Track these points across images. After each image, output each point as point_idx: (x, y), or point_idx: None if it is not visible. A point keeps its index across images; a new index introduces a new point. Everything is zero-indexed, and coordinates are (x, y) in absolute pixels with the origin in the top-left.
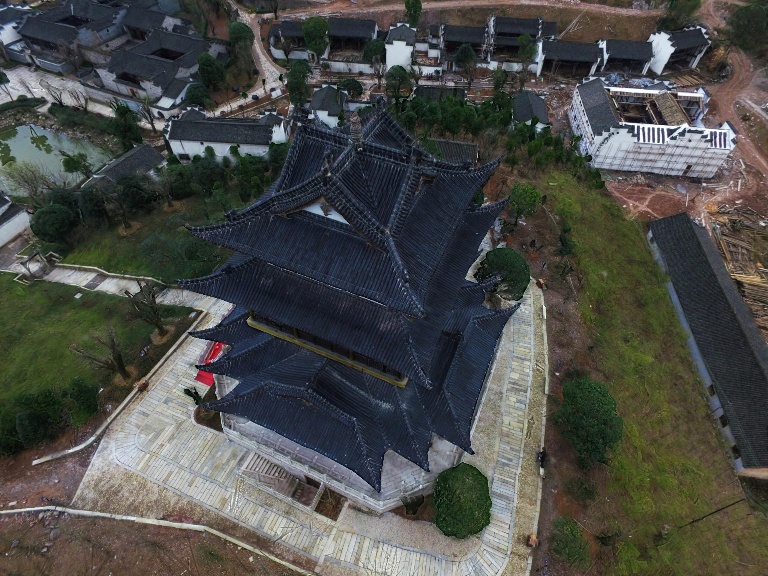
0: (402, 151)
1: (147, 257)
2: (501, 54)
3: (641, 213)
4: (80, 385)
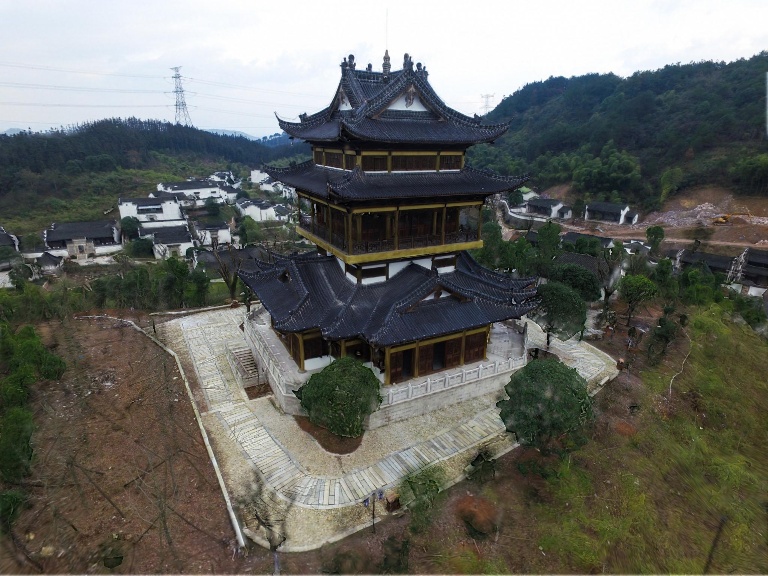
0: None
1: None
2: None
3: None
4: (201, 264)
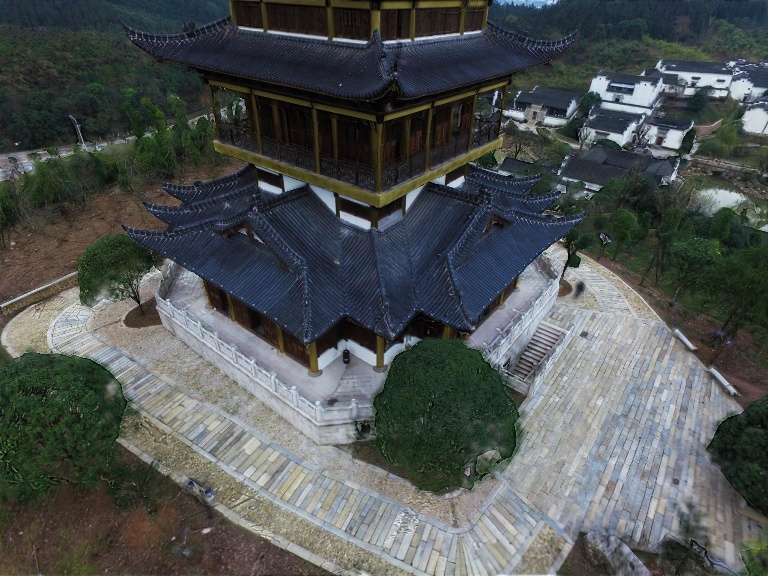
0: None
1: None
2: None
3: None
4: None
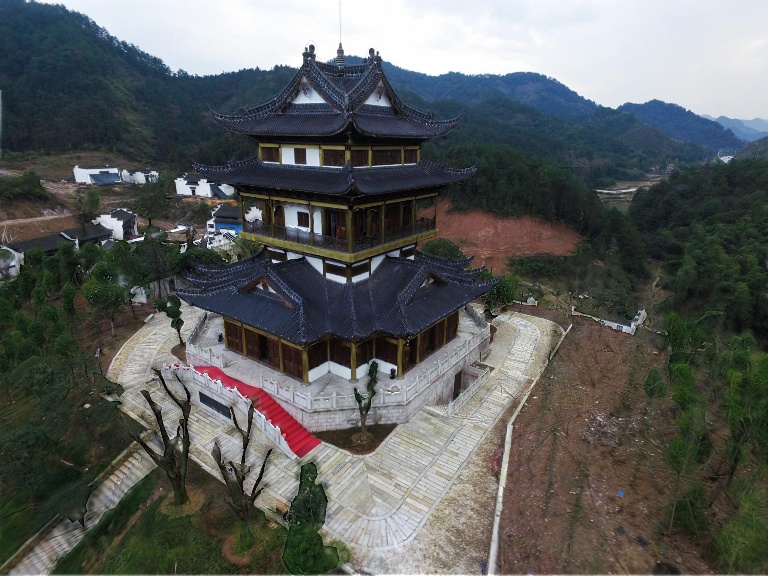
0: None
1: None
2: None
3: None
4: (313, 465)
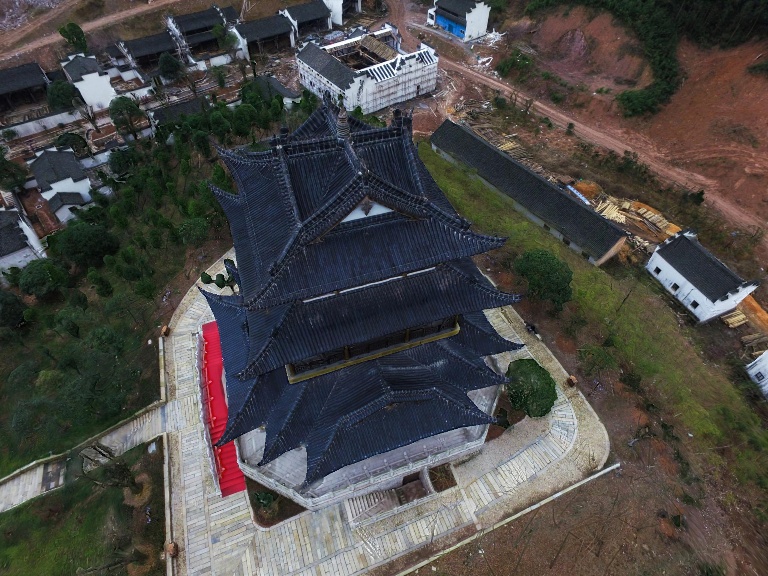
0: (392, 126)
1: (1, 447)
2: (199, 52)
3: (414, 136)
4: None
